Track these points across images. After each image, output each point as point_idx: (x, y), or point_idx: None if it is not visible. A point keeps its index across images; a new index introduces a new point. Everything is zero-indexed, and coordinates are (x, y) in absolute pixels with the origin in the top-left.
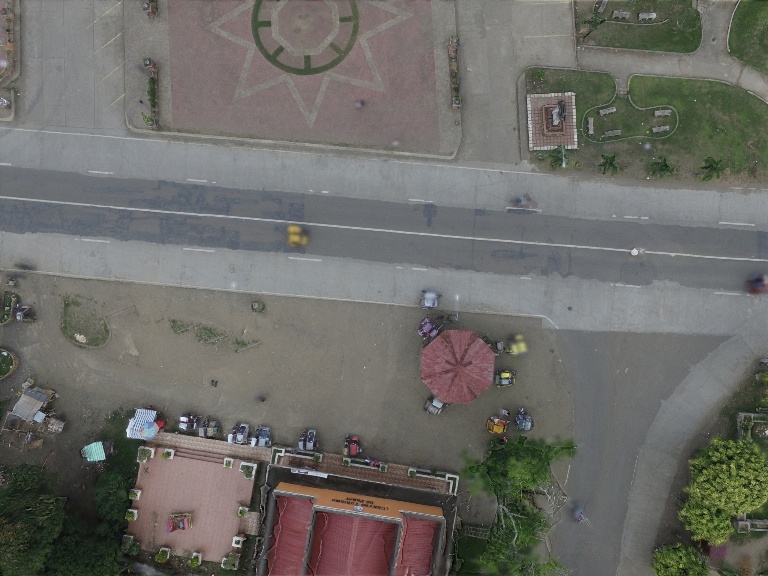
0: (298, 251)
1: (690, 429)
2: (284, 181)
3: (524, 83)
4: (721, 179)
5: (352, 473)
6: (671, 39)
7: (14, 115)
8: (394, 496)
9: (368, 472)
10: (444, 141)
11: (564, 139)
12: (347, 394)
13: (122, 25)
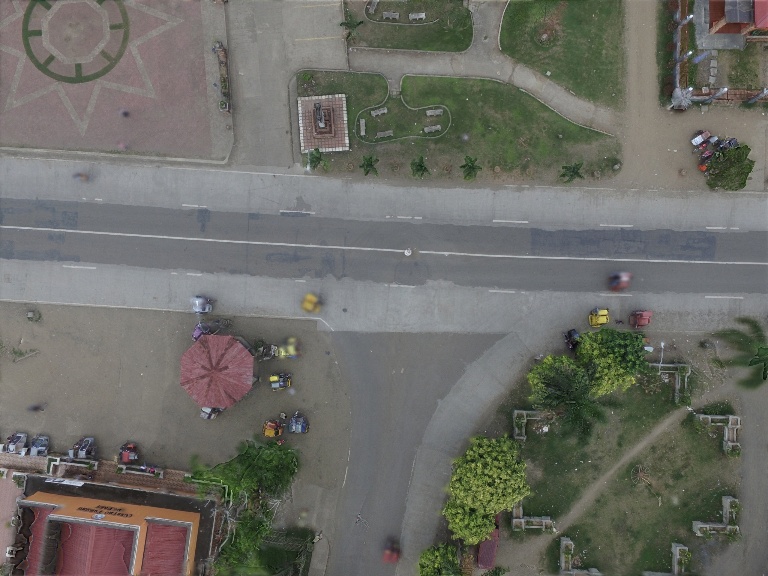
0: (72, 259)
1: (467, 428)
2: (57, 190)
3: (295, 86)
4: (494, 177)
5: (130, 480)
6: (442, 38)
7: None
8: (152, 503)
9: (146, 479)
10: (216, 146)
11: (335, 141)
12: (125, 401)
13: None
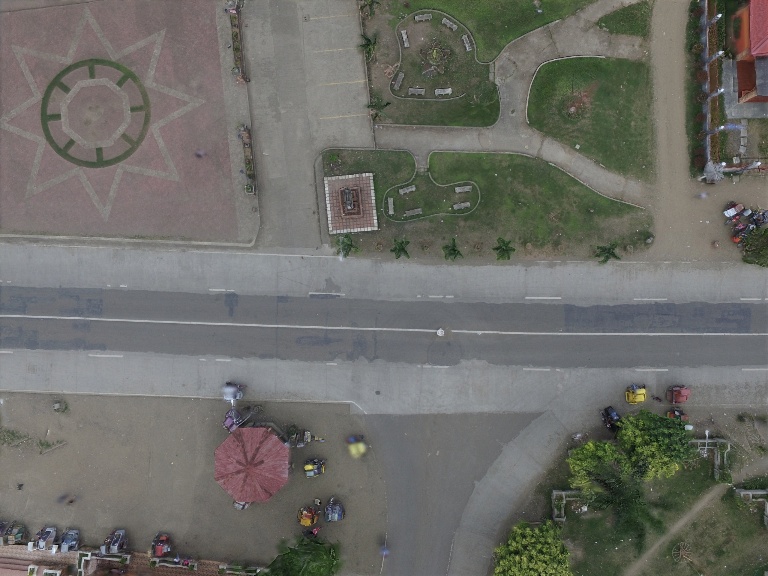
0: (98, 348)
1: (505, 509)
2: (81, 277)
3: (321, 165)
4: (525, 253)
5: (163, 572)
6: (469, 113)
7: None
8: None
9: (179, 570)
10: (242, 229)
11: (363, 221)
12: (156, 491)
13: None
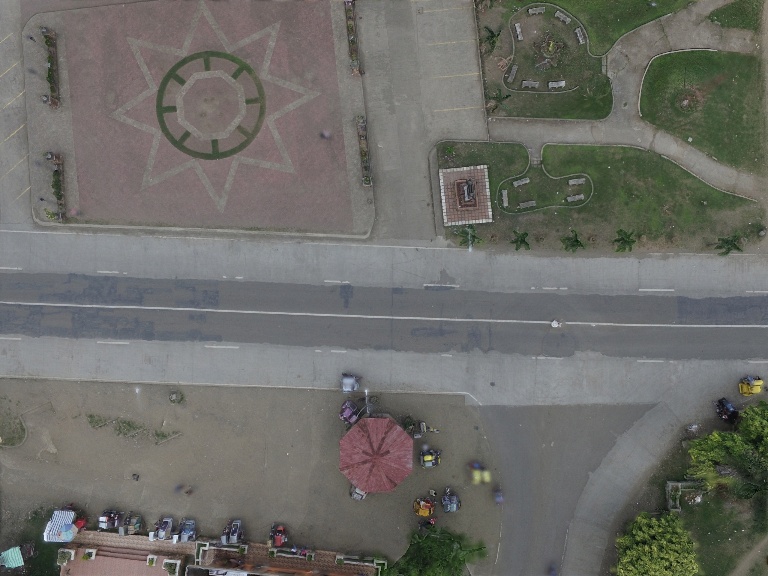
0: (214, 339)
1: (619, 500)
2: (197, 268)
3: (436, 158)
4: (638, 246)
5: (279, 563)
6: (582, 106)
7: None
8: None
9: (296, 561)
10: (357, 220)
11: (478, 213)
12: (271, 482)
13: (25, 116)
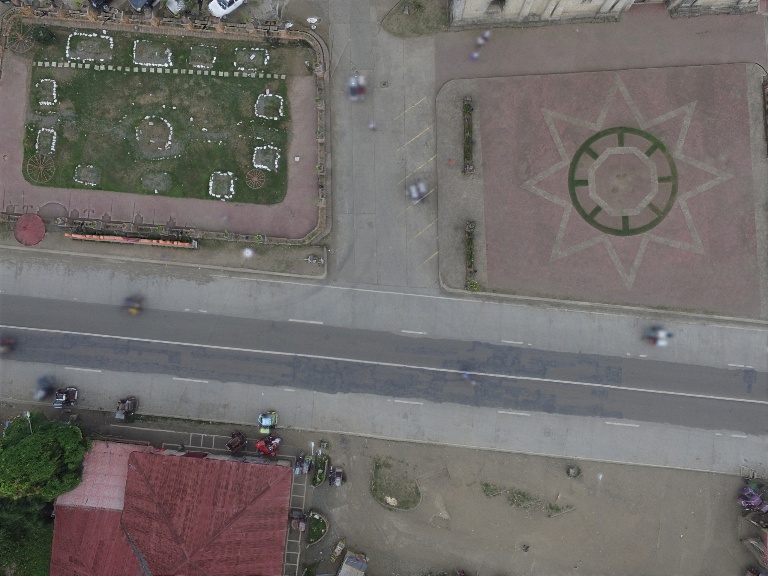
0: (615, 416)
1: None
2: (601, 344)
3: None
4: None
5: None
6: None
7: (327, 273)
8: None
9: None
10: (765, 306)
11: None
12: (663, 562)
13: (435, 181)
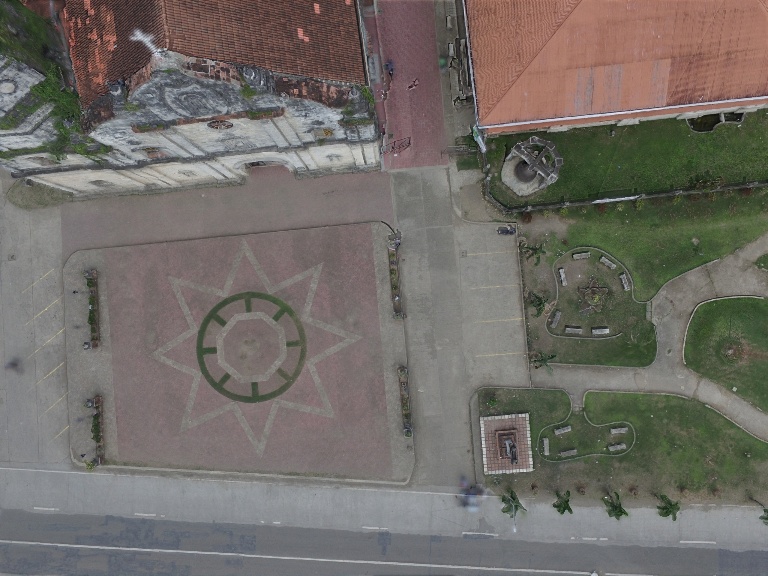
0: None
1: None
2: (235, 512)
3: (477, 404)
4: (680, 497)
5: None
6: (626, 353)
7: None
8: None
9: None
10: (397, 467)
11: (519, 462)
12: None
13: (64, 354)
